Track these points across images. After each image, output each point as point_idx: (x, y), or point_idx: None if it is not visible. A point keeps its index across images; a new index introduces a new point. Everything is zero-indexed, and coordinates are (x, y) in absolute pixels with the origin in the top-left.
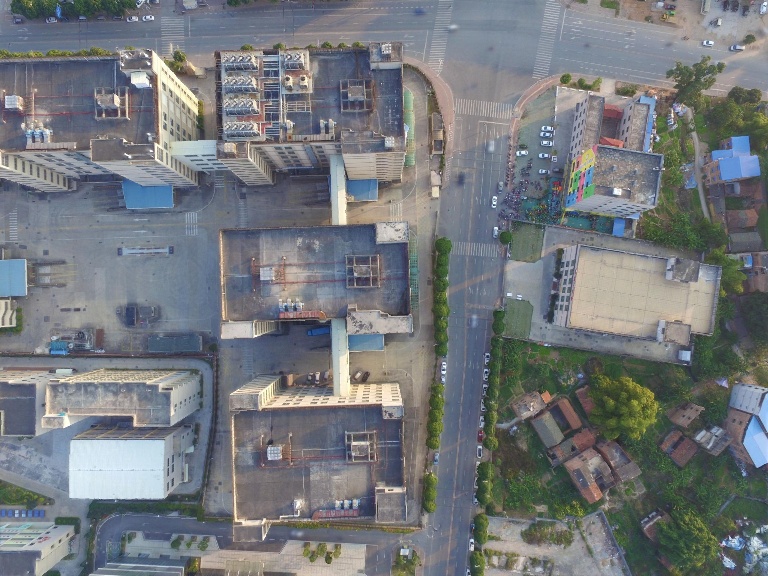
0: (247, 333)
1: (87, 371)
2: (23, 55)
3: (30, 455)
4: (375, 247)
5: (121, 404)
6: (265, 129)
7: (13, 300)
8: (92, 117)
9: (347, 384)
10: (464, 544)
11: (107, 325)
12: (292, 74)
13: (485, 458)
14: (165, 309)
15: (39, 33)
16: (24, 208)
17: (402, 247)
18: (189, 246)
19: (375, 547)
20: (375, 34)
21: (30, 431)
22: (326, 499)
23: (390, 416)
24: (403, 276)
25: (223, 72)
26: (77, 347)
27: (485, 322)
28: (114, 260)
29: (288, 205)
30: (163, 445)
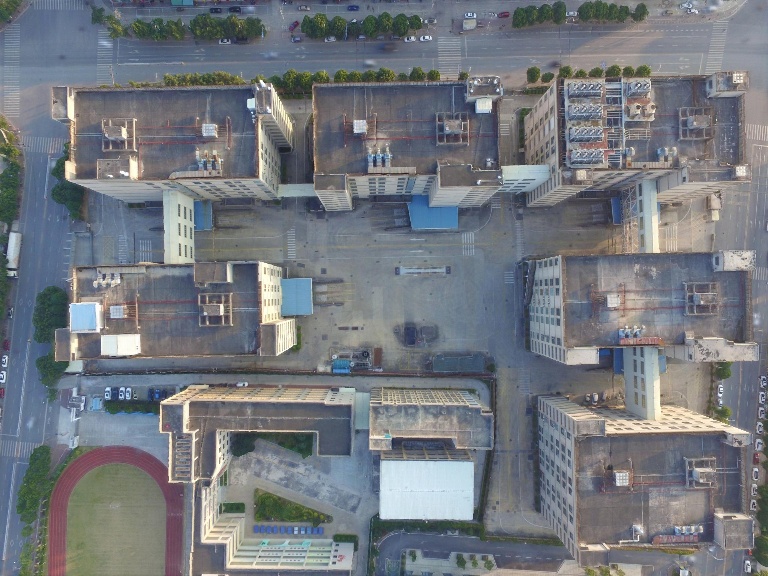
0: (592, 359)
1: (372, 390)
2: (311, 75)
3: (308, 472)
4: (712, 274)
5: (441, 426)
6: (608, 156)
7: (296, 318)
8: (431, 142)
9: (660, 408)
10: (739, 565)
11: (385, 344)
12: (634, 102)
13: (760, 480)
14: (442, 329)
15: (316, 52)
16: (302, 226)
17: (739, 275)
18: (466, 266)
19: (651, 568)
20: (650, 57)
21: (344, 452)
22: (664, 524)
23: (739, 444)
24: (740, 304)
25: (566, 99)
26: (360, 366)
27: (760, 345)
28: (391, 279)
29: (564, 226)
30: (472, 467)
